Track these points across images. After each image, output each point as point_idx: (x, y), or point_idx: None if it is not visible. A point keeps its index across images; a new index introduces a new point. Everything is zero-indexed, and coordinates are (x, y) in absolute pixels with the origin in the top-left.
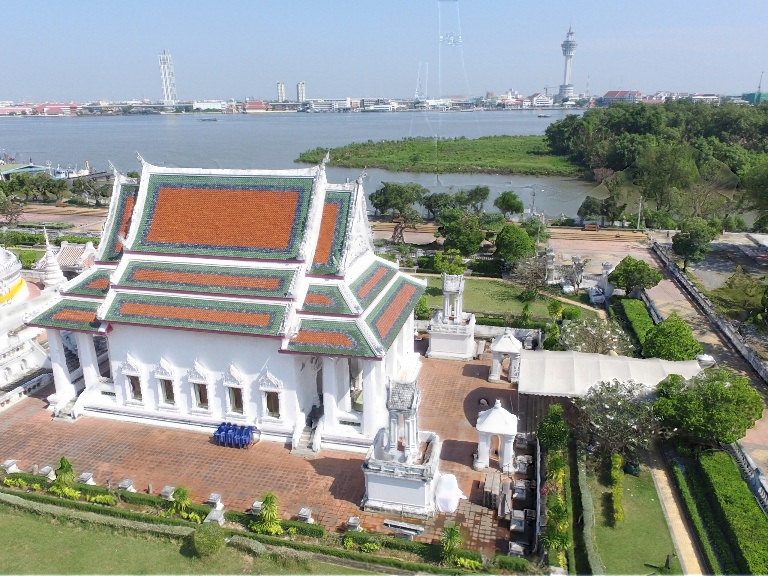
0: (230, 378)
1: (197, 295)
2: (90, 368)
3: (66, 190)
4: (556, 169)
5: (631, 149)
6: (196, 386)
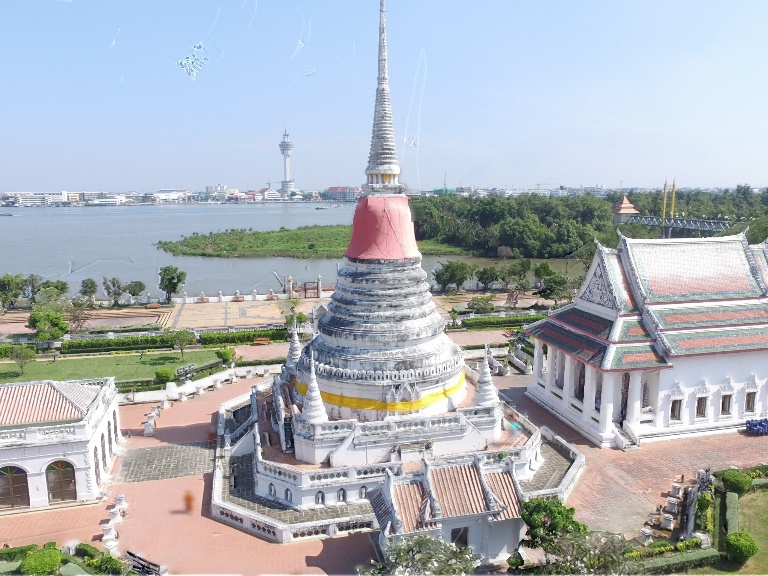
0: (752, 385)
1: (722, 328)
2: (639, 402)
3: (68, 292)
4: (447, 250)
5: (520, 230)
6: (722, 398)
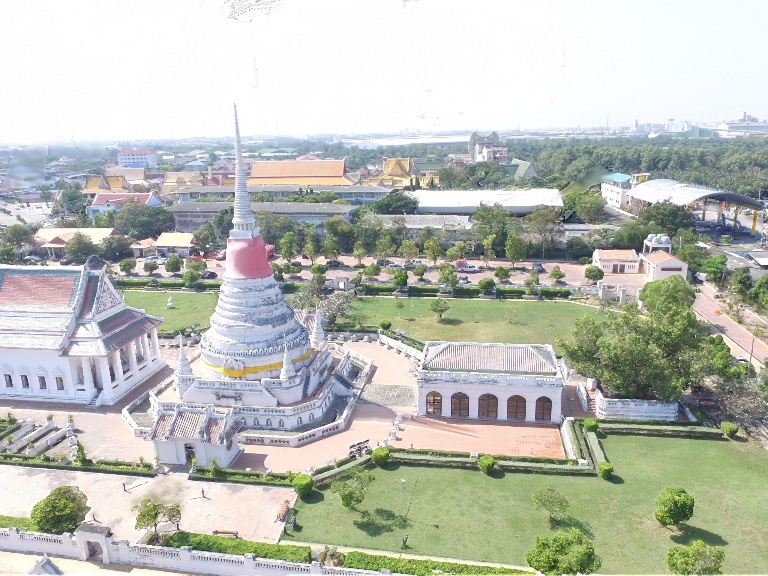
0: None
1: None
2: None
3: None
4: None
5: None
6: None
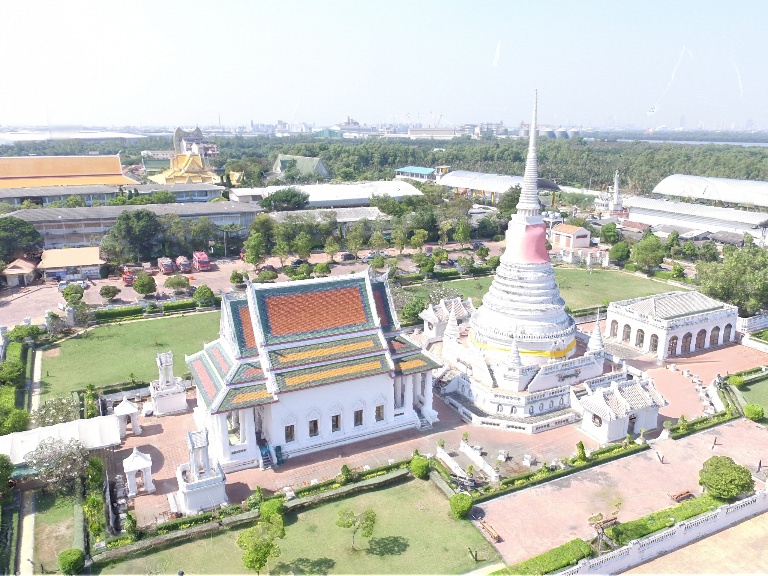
0: None
1: None
2: None
3: None
4: None
5: None
6: None
